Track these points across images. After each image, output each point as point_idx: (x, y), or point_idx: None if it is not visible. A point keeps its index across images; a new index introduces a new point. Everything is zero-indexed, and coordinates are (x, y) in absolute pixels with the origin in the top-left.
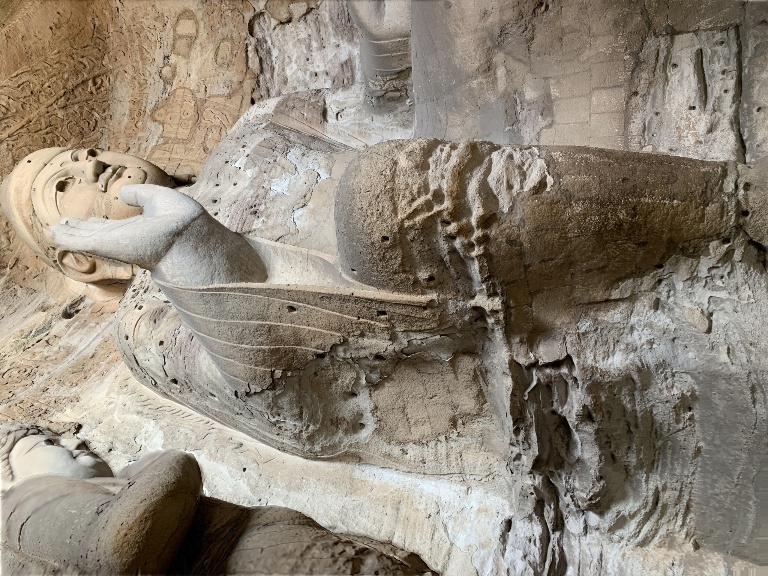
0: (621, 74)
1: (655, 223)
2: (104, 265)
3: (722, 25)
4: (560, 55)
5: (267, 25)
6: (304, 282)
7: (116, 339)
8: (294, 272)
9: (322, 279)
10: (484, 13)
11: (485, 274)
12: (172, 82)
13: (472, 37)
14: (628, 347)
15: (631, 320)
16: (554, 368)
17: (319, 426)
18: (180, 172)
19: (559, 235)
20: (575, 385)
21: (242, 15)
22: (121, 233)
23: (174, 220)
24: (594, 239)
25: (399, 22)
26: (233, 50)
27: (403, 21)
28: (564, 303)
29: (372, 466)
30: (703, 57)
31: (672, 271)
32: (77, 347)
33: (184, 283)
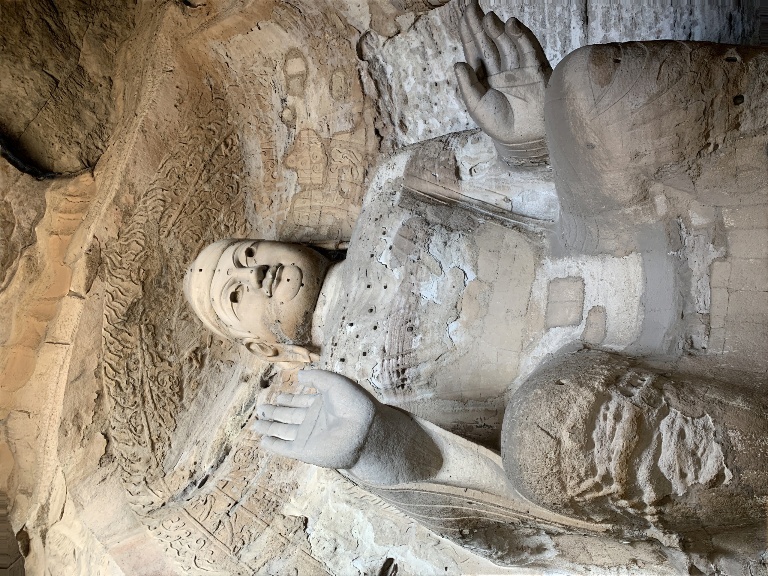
0: None
1: None
2: (285, 352)
3: None
4: (735, 188)
5: (375, 42)
6: (478, 476)
7: None
8: (467, 462)
9: (495, 478)
10: (635, 155)
11: (660, 528)
12: (295, 125)
13: (622, 174)
14: None
15: None
16: None
17: (507, 552)
18: (323, 221)
19: (740, 516)
20: None
21: (348, 41)
22: (314, 453)
23: (355, 434)
24: None
25: (532, 129)
26: (346, 80)
27: (536, 128)
28: (747, 540)
29: (558, 574)
30: None
31: None
32: None
33: (374, 483)
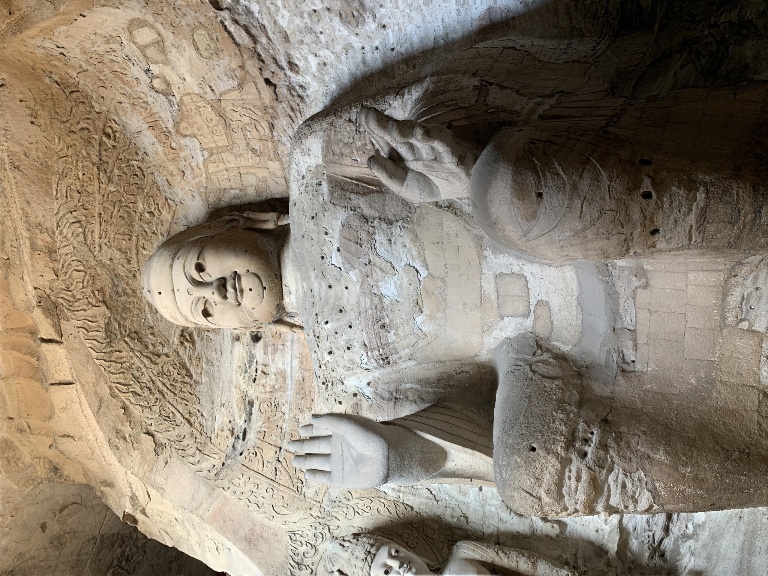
0: None
1: None
2: (267, 327)
3: None
4: None
5: None
6: (477, 465)
7: None
8: (466, 456)
9: (490, 467)
10: None
11: None
12: (172, 92)
13: None
14: None
15: None
16: None
17: None
18: (246, 182)
19: None
20: None
21: None
22: (353, 487)
23: (379, 469)
24: None
25: (459, 196)
26: (211, 35)
27: None
28: None
29: None
30: None
31: None
32: (285, 370)
33: None
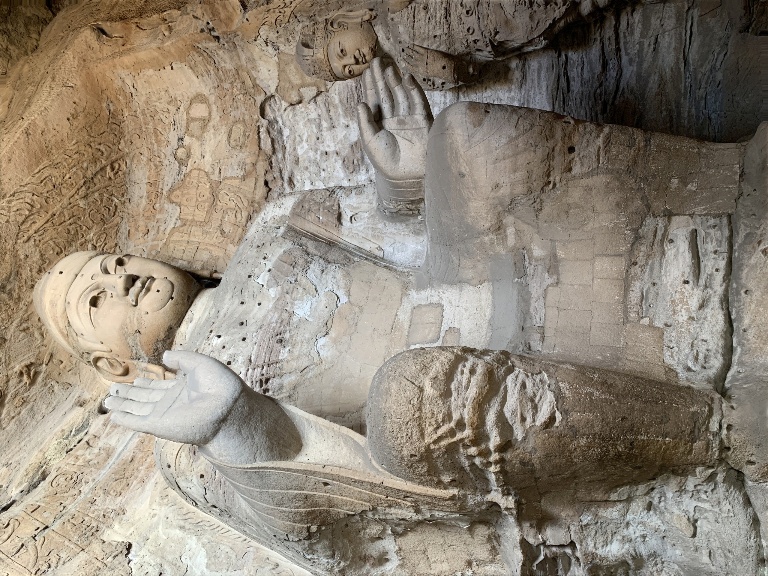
0: (622, 245)
1: (649, 454)
2: (137, 370)
3: (715, 213)
4: (566, 224)
5: (278, 106)
6: (337, 457)
7: (158, 465)
8: (327, 444)
9: (353, 457)
10: (496, 185)
11: (501, 483)
12: (187, 163)
13: (484, 203)
14: (624, 538)
15: (627, 517)
16: (559, 547)
17: (349, 562)
18: (199, 256)
19: (566, 460)
20: (577, 563)
21: (253, 99)
22: (173, 422)
23: (219, 405)
24: (596, 464)
25: (413, 167)
26: (245, 132)
27: (417, 167)
28: (569, 500)
29: None
30: (697, 236)
31: (663, 484)
32: (116, 448)
33: (230, 461)
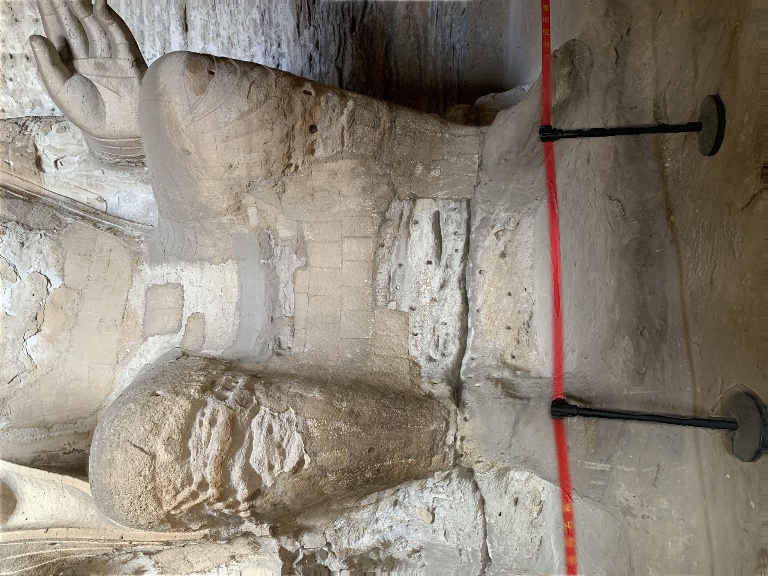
0: (369, 227)
1: (394, 474)
2: None
3: (456, 197)
4: (312, 206)
5: None
6: (63, 511)
7: None
8: (49, 497)
9: (84, 509)
10: (229, 166)
11: (253, 521)
12: None
13: (218, 183)
14: (374, 531)
15: (376, 515)
16: None
17: None
18: None
19: (317, 494)
20: (334, 557)
21: None
22: None
23: None
24: (346, 490)
25: (126, 126)
26: None
27: (131, 126)
28: (323, 512)
29: None
30: (440, 217)
31: (407, 486)
32: None
33: None
